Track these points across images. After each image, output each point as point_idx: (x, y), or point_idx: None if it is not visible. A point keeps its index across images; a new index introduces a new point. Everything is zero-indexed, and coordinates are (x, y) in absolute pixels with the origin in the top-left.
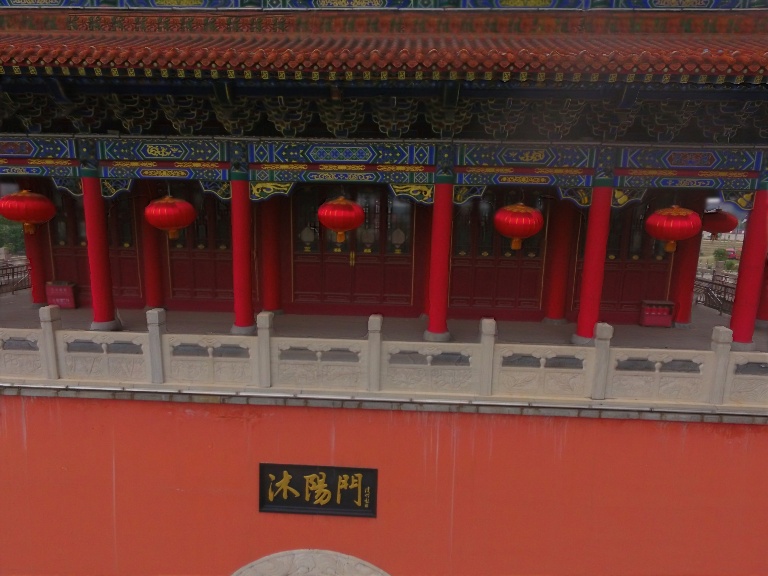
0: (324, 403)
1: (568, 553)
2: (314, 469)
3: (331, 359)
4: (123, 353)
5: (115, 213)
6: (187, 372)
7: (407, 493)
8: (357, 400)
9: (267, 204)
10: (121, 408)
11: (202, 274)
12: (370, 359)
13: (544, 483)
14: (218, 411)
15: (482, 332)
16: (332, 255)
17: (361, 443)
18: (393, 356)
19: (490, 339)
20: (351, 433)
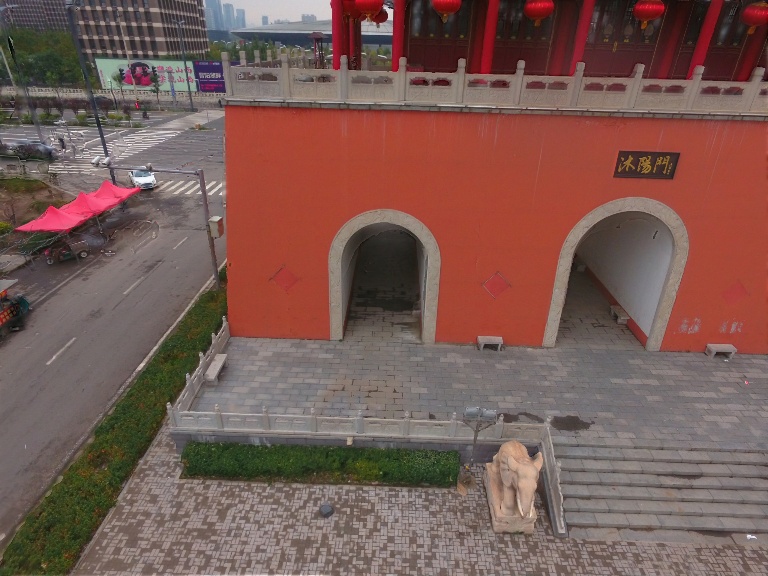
0: (663, 116)
1: (763, 196)
2: (646, 154)
3: (669, 92)
4: (555, 89)
5: (457, 11)
6: (589, 100)
7: (692, 166)
8: (681, 114)
9: (567, 4)
10: (552, 121)
11: (511, 58)
12: (692, 91)
13: (763, 159)
14: (603, 122)
15: (755, 75)
16: (602, 44)
17: (675, 139)
18: (703, 90)
19: (759, 78)
20: (671, 133)
